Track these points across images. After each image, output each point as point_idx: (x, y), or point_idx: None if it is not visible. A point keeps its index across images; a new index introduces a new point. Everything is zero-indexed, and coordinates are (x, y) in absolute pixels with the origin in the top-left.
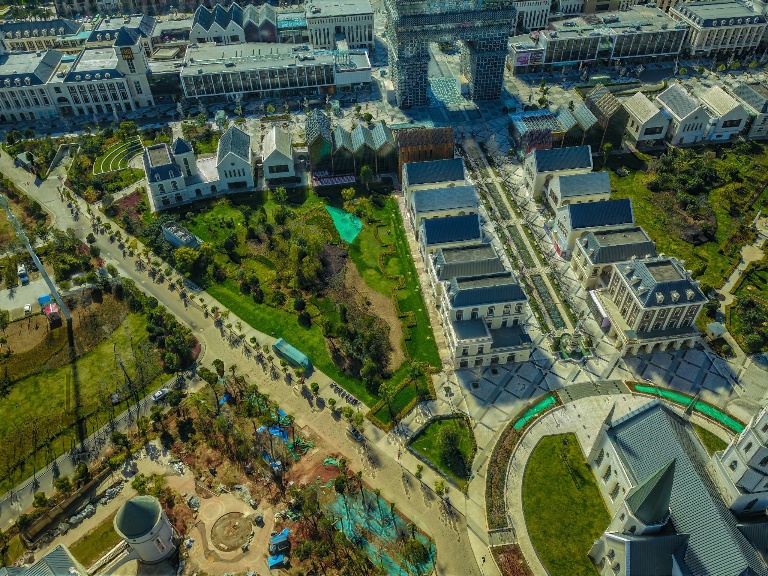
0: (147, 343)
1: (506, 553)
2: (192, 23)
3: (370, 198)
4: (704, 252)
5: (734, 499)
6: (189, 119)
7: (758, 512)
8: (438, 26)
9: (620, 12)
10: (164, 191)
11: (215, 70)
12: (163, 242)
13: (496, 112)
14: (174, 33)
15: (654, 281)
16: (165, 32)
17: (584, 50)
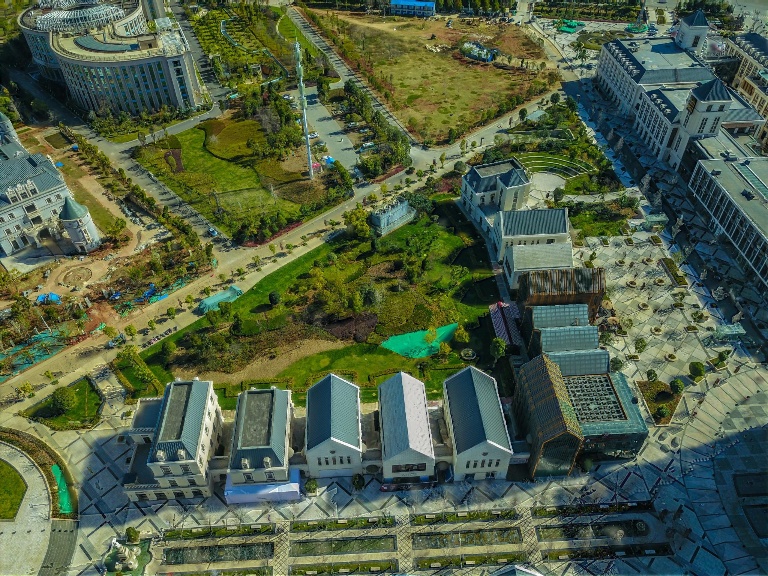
0: None
1: None
2: None
3: None
4: None
5: None
6: (649, 199)
7: None
8: None
9: None
10: None
11: (727, 184)
12: None
13: None
14: None
15: None
16: None
17: None
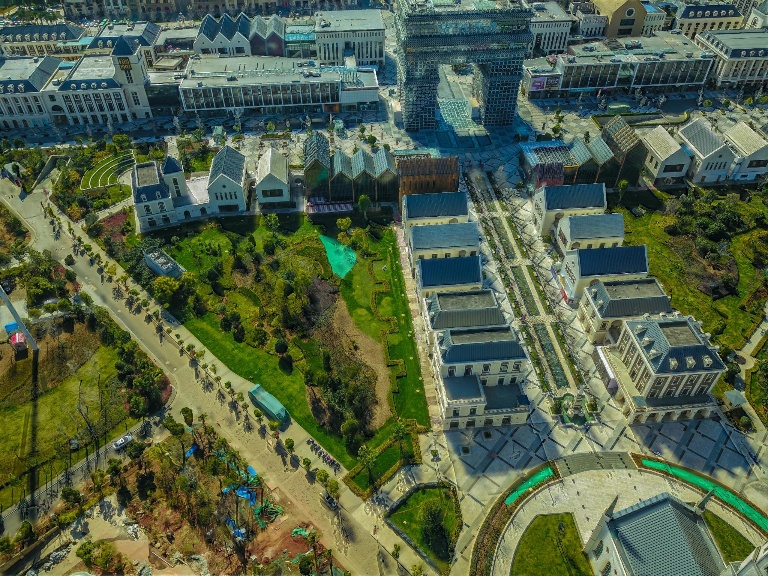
0: (115, 382)
1: None
2: (197, 32)
3: (367, 228)
4: (724, 307)
5: None
6: (186, 133)
7: None
8: (449, 48)
9: (643, 38)
10: (150, 212)
11: (216, 84)
12: (144, 269)
13: (507, 139)
14: (179, 42)
15: (668, 344)
16: (169, 41)
17: (603, 77)
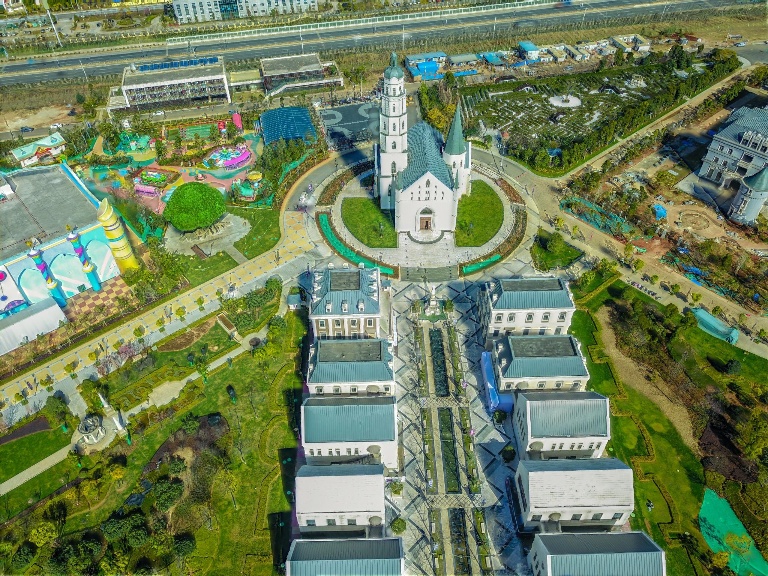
0: None
1: None
2: None
3: None
4: (221, 400)
5: None
6: None
7: None
8: None
9: None
10: None
11: None
12: None
13: None
14: None
15: None
16: None
17: None
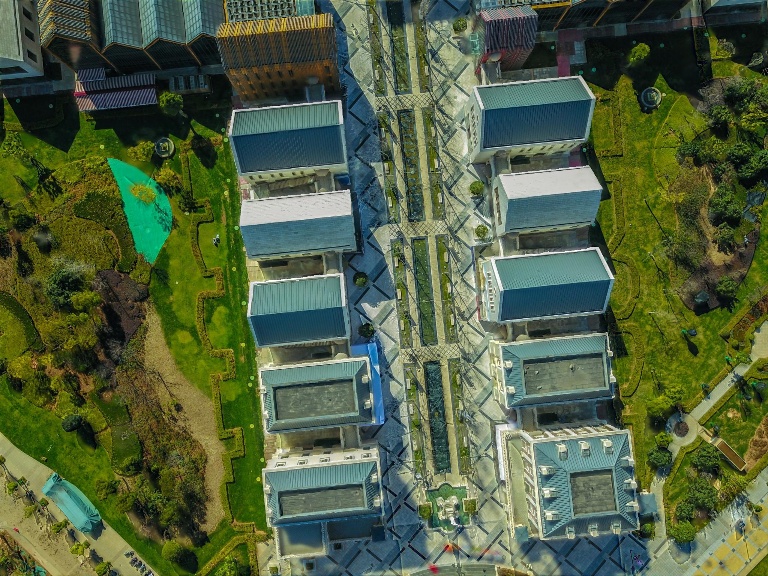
0: None
1: None
2: None
3: (188, 140)
4: (700, 332)
5: None
6: None
7: None
8: None
9: None
10: None
11: None
12: None
13: None
14: None
15: (571, 514)
16: None
17: None
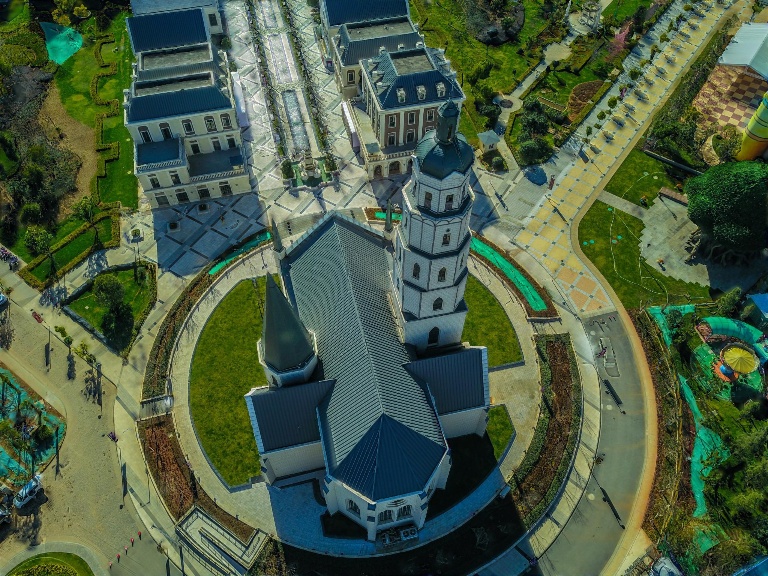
0: None
1: (154, 426)
2: None
3: (103, 10)
4: (501, 53)
5: (404, 330)
6: None
7: (450, 345)
8: None
9: None
10: None
11: None
12: None
13: None
14: None
15: (395, 74)
16: None
17: None
